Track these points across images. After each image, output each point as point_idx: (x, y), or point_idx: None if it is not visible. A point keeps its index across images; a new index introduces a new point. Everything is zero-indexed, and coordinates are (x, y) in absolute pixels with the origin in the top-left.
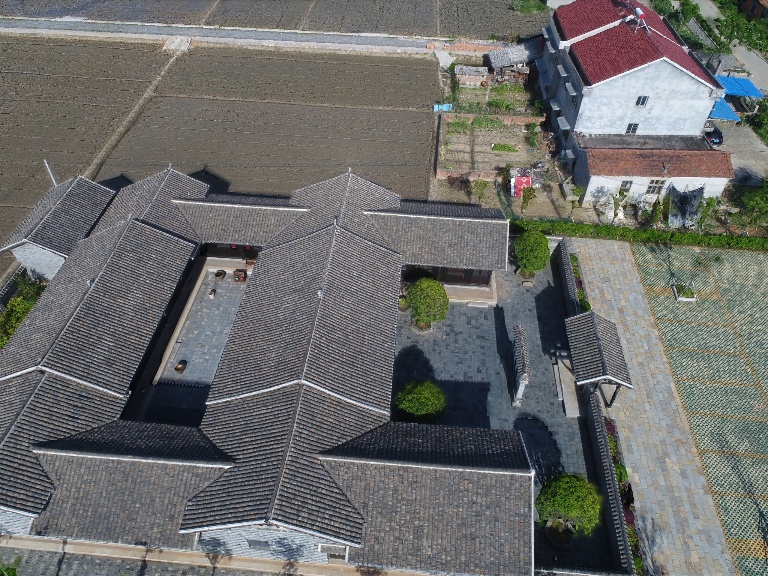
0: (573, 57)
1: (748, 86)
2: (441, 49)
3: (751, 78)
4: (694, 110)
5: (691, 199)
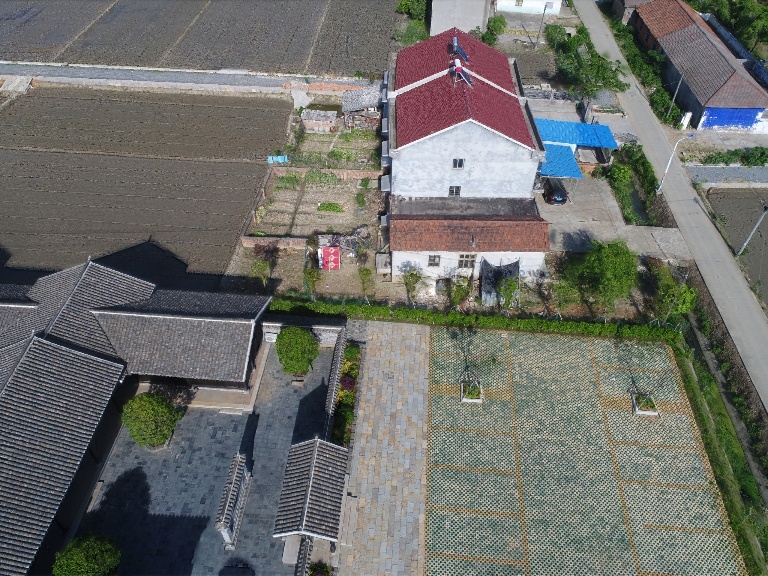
0: (396, 110)
1: (605, 134)
2: (298, 89)
3: (625, 119)
4: (518, 172)
5: (506, 274)
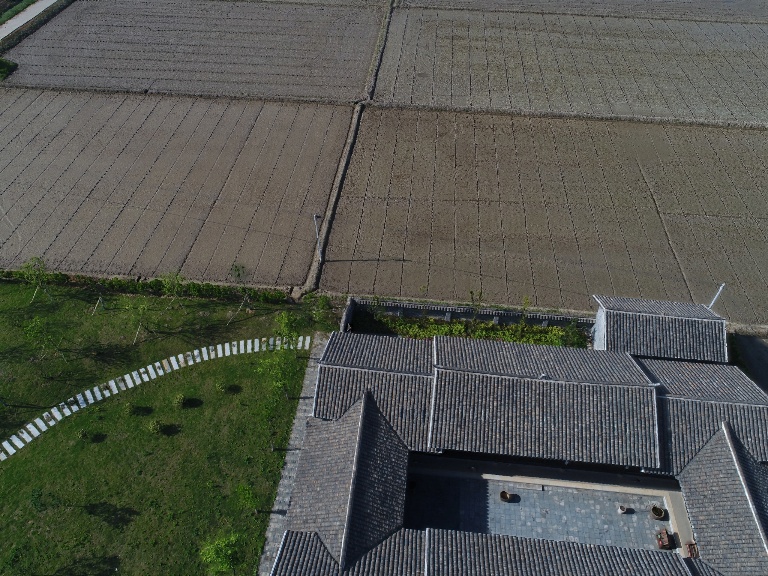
0: None
1: None
2: None
3: None
4: None
5: None
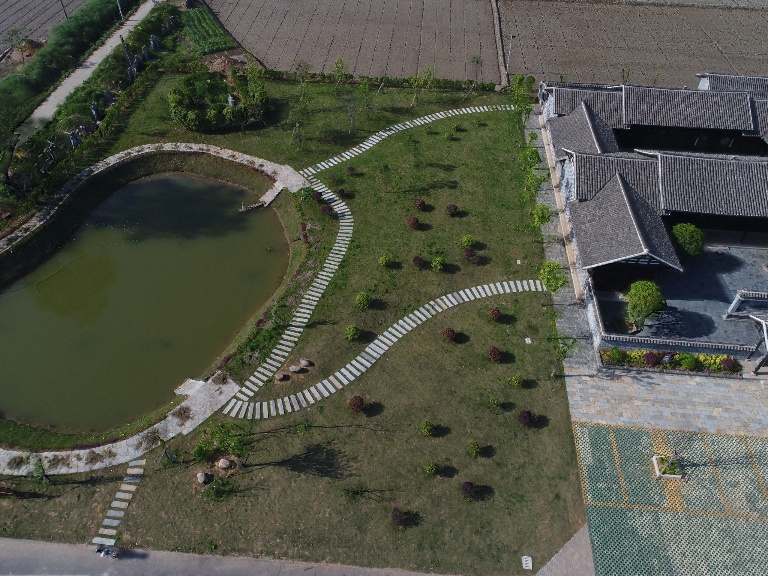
0: None
1: None
2: None
3: None
4: None
5: None
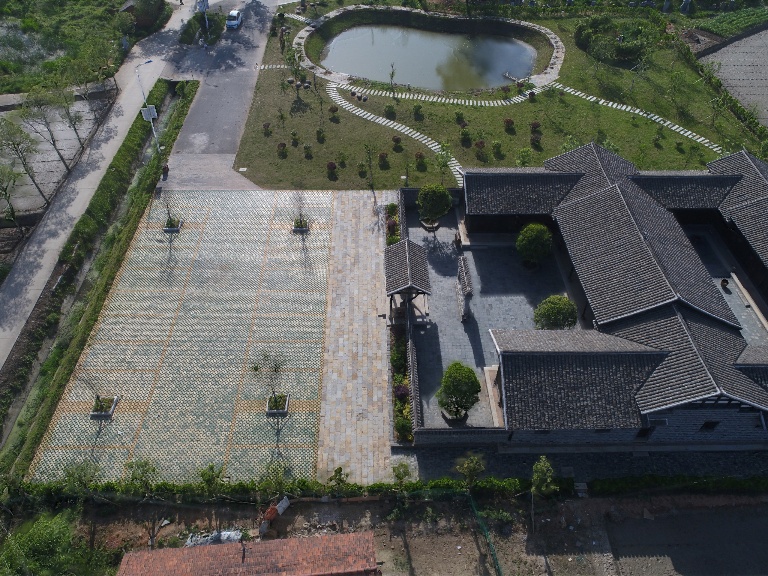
0: None
1: None
2: None
3: None
4: None
5: None
